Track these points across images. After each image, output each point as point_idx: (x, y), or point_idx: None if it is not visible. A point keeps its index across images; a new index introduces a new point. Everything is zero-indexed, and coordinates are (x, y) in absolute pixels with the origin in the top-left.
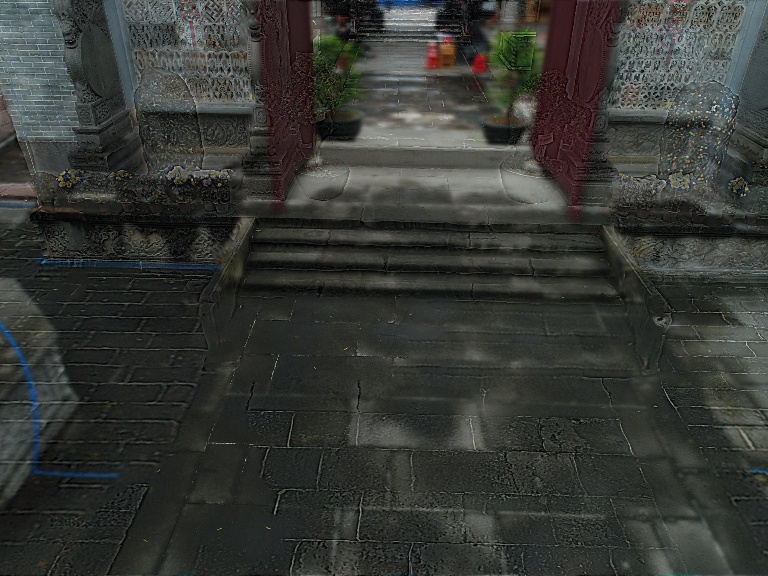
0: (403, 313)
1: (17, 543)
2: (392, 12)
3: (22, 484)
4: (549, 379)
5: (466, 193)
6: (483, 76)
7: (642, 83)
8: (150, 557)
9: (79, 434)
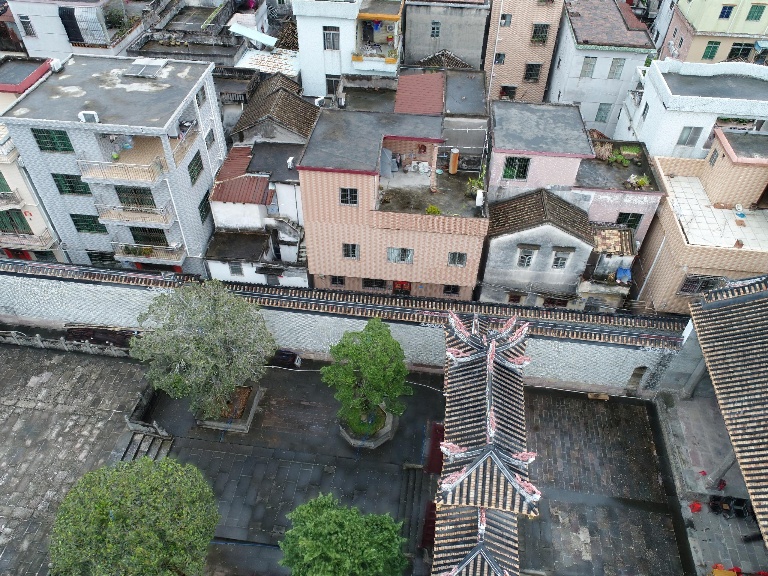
0: (526, 533)
1: None
2: (66, 474)
3: None
4: (539, 508)
5: None
6: (280, 455)
7: None
8: None
9: None
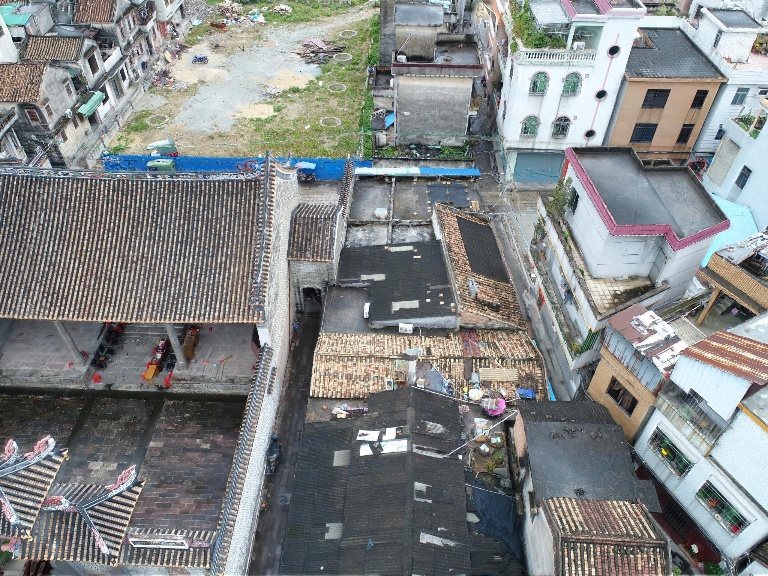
0: None
1: (154, 470)
2: None
3: (156, 479)
4: None
5: None
6: None
7: None
8: (136, 468)
9: (149, 489)
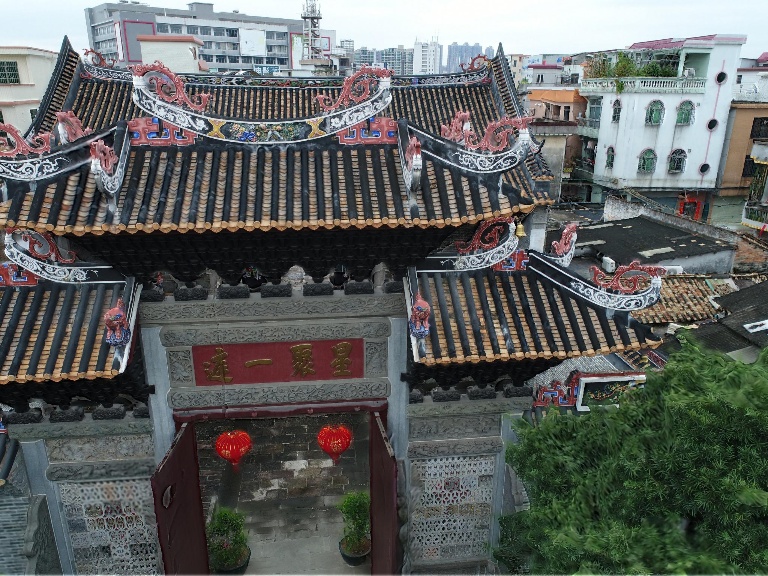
0: None
1: None
2: None
3: None
4: None
5: (269, 572)
6: None
7: (138, 568)
8: None
9: None
